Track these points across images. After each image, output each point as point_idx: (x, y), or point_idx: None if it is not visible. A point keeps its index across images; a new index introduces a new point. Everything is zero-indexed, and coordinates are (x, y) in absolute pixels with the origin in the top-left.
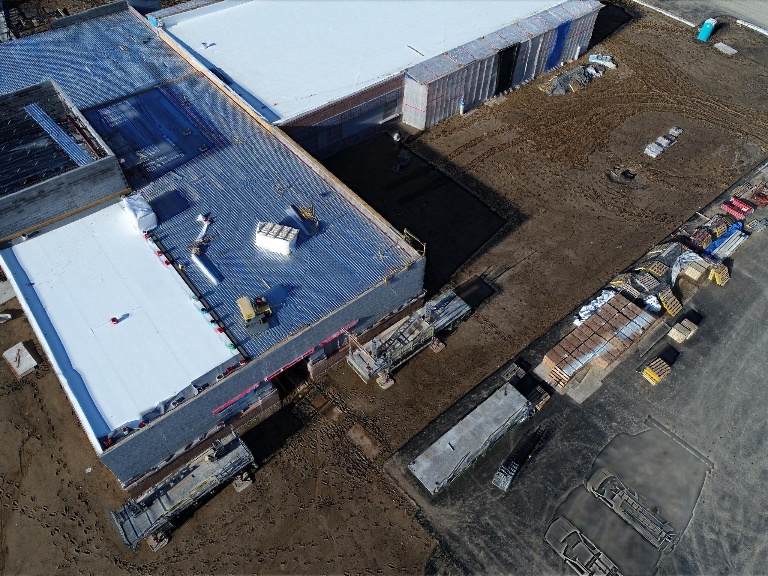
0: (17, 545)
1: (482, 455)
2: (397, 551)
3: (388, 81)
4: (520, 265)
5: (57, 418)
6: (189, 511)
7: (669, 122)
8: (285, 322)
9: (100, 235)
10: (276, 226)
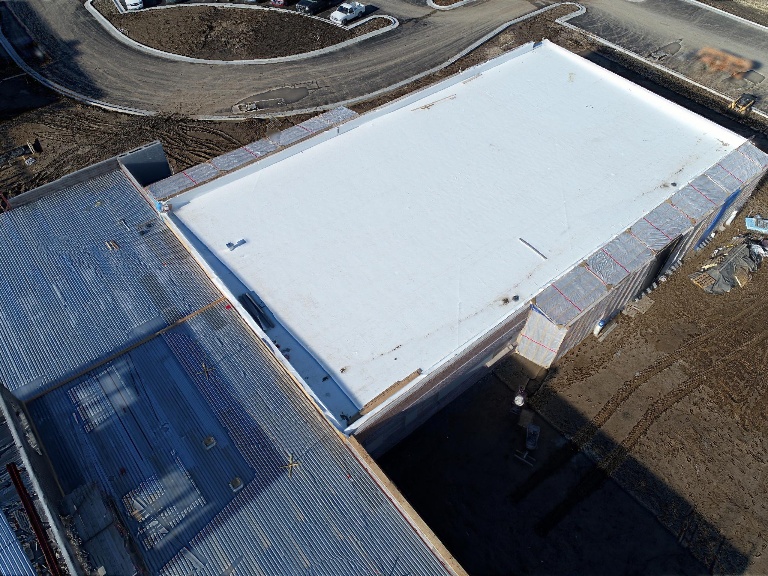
0: None
1: None
2: None
3: (509, 322)
4: None
5: None
6: None
7: None
8: None
9: None
10: None
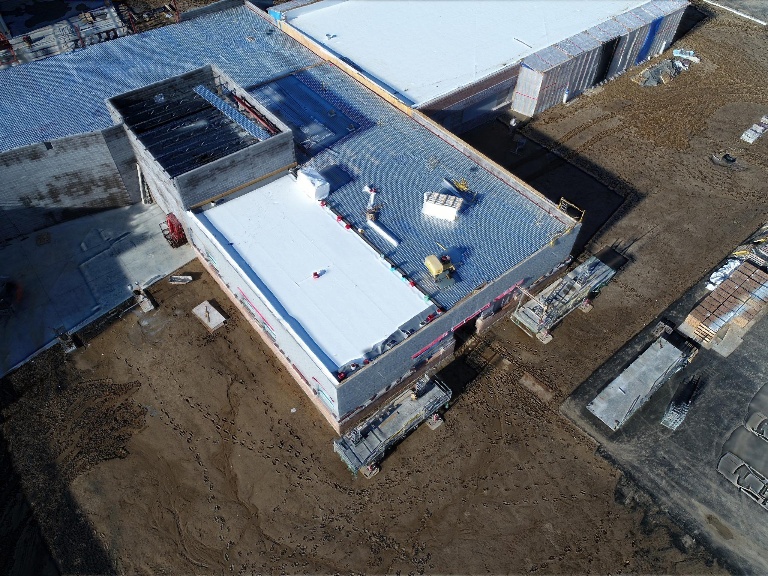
0: (245, 472)
1: (647, 400)
2: (586, 480)
3: (507, 70)
4: (646, 237)
5: (254, 366)
6: (392, 445)
7: (758, 111)
8: (466, 278)
9: (279, 203)
10: (441, 195)
